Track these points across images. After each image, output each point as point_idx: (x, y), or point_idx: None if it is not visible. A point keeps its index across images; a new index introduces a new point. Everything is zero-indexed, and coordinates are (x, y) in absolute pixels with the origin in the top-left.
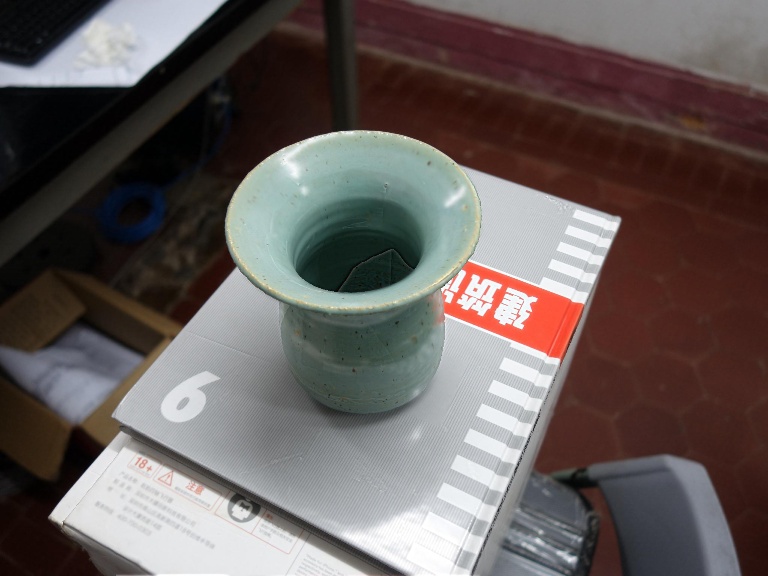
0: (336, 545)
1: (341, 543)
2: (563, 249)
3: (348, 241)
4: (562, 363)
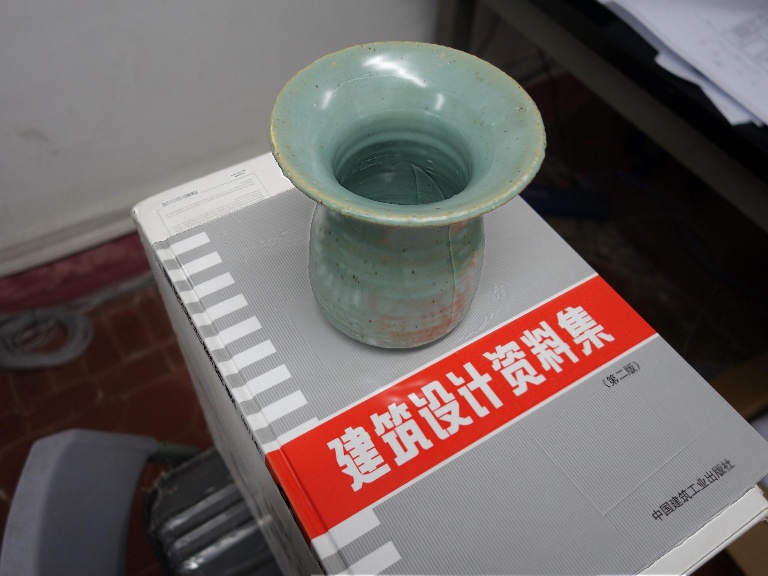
0: None
1: None
2: None
3: None
4: None
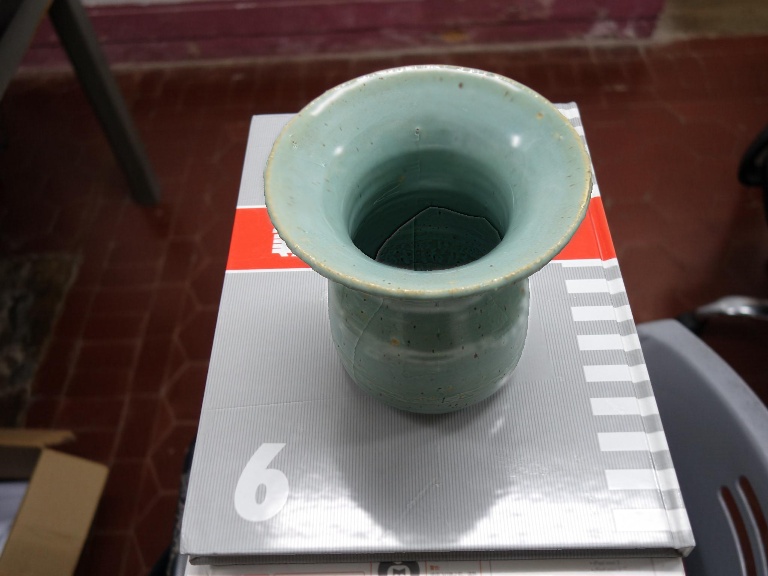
0: (526, 558)
1: (531, 553)
2: None
3: (375, 219)
4: None
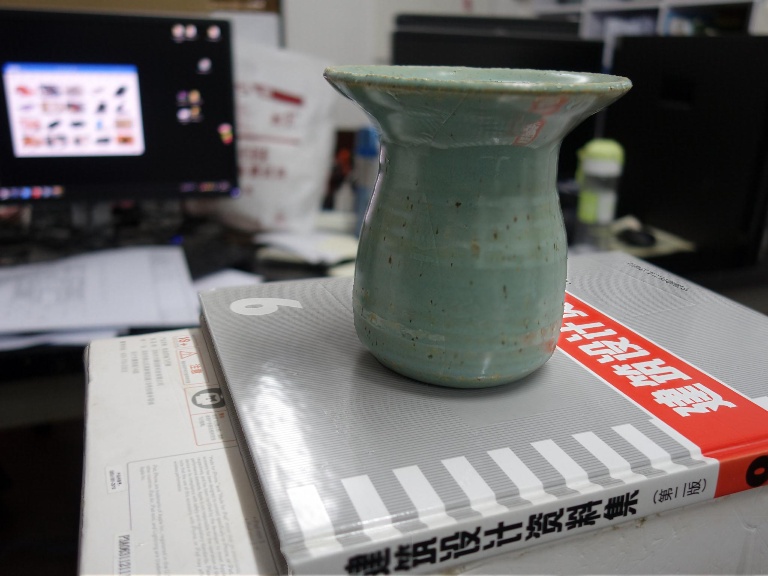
0: (246, 464)
1: (251, 464)
2: None
3: None
4: (746, 529)
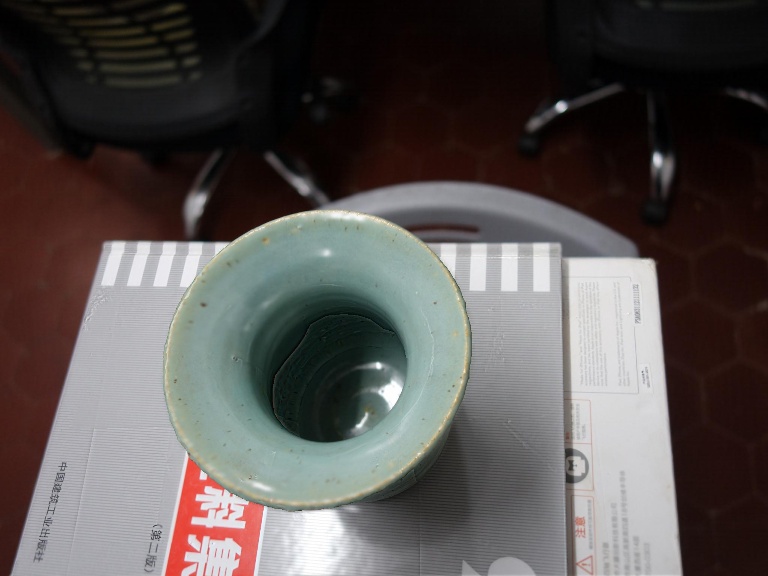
0: None
1: None
2: (163, 281)
3: None
4: None
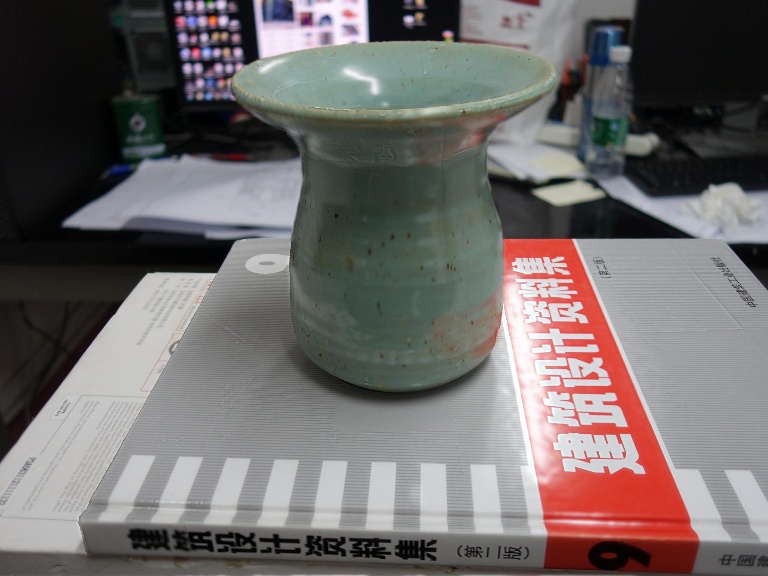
0: None
1: None
2: None
3: None
4: None
